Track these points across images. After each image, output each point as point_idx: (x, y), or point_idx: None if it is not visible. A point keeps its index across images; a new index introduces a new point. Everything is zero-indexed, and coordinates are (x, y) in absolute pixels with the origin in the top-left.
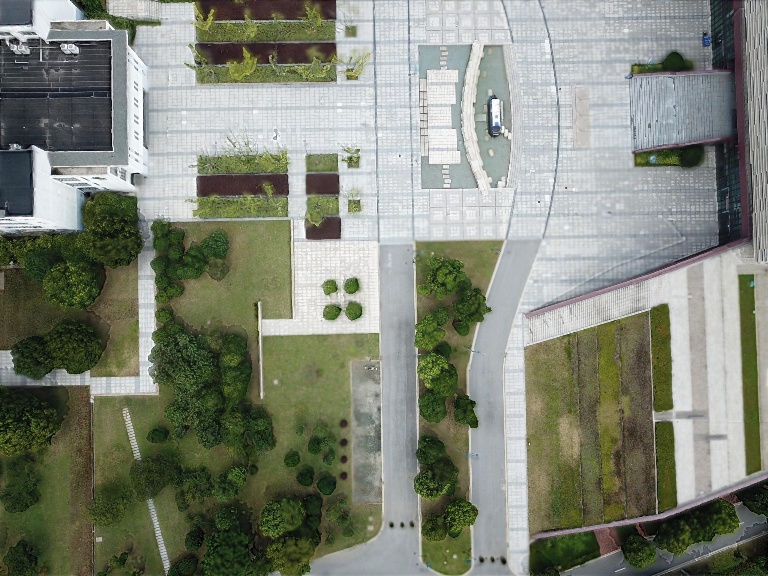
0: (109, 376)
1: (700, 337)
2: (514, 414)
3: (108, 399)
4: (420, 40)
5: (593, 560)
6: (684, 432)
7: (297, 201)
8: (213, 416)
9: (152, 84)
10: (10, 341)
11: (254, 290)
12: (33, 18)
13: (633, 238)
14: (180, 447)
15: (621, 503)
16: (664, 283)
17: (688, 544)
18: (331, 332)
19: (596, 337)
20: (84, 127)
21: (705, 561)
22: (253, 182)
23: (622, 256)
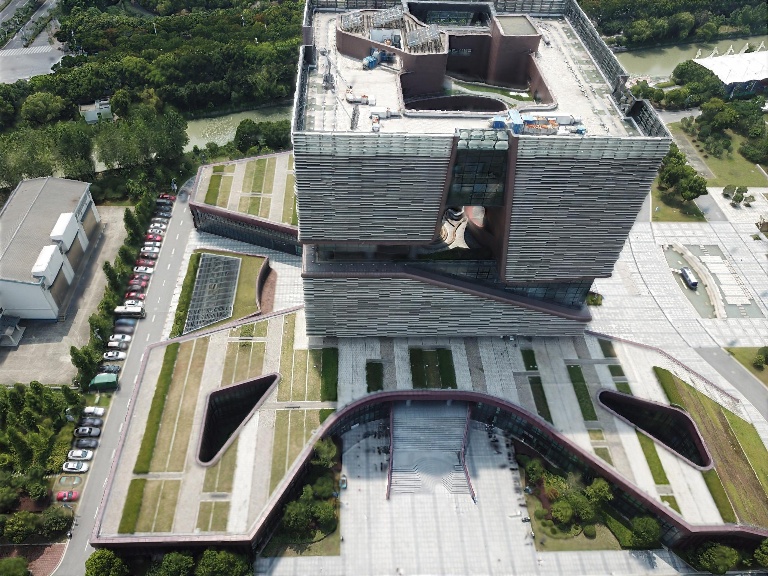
0: None
1: None
2: None
3: None
4: (767, 321)
5: None
6: None
7: None
8: None
9: None
10: None
11: None
12: None
13: None
14: None
15: None
16: None
17: None
18: None
19: None
20: None
21: None
22: None
23: None
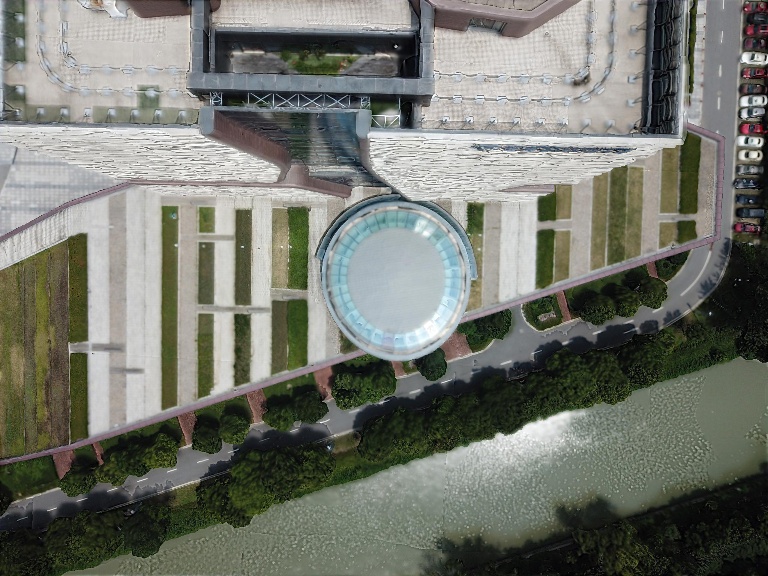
0: None
1: (120, 269)
2: None
3: None
4: None
5: (55, 489)
6: (100, 365)
7: None
8: None
9: None
10: None
11: None
12: None
13: None
14: None
15: (48, 433)
16: (84, 212)
17: (114, 476)
18: None
19: (35, 266)
20: None
21: (167, 495)
22: None
23: (94, 185)
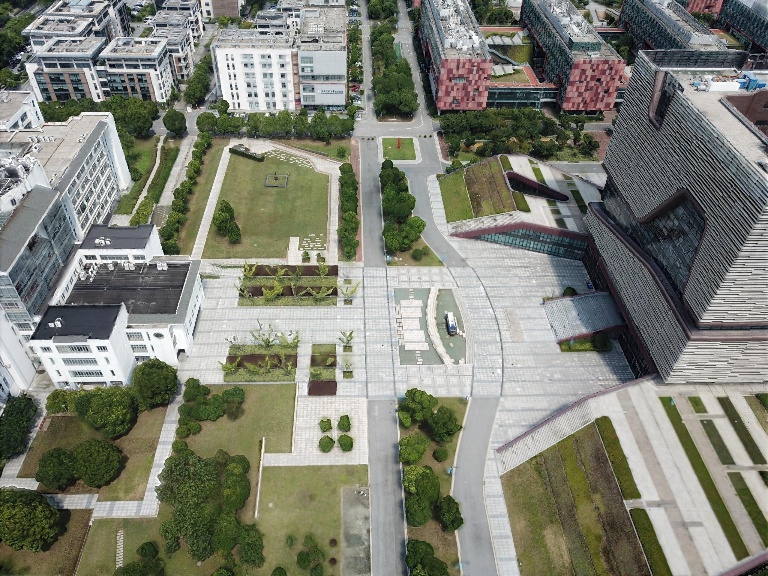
0: (114, 500)
1: (645, 441)
2: (500, 535)
3: (107, 521)
4: (395, 286)
5: None
6: (660, 519)
7: (303, 372)
8: (207, 525)
9: (206, 306)
10: (34, 470)
11: (261, 431)
12: (146, 246)
13: (574, 396)
14: (166, 568)
15: None
16: (600, 402)
17: None
18: (325, 463)
19: (558, 452)
20: (159, 304)
21: None
22: (270, 358)
23: None
